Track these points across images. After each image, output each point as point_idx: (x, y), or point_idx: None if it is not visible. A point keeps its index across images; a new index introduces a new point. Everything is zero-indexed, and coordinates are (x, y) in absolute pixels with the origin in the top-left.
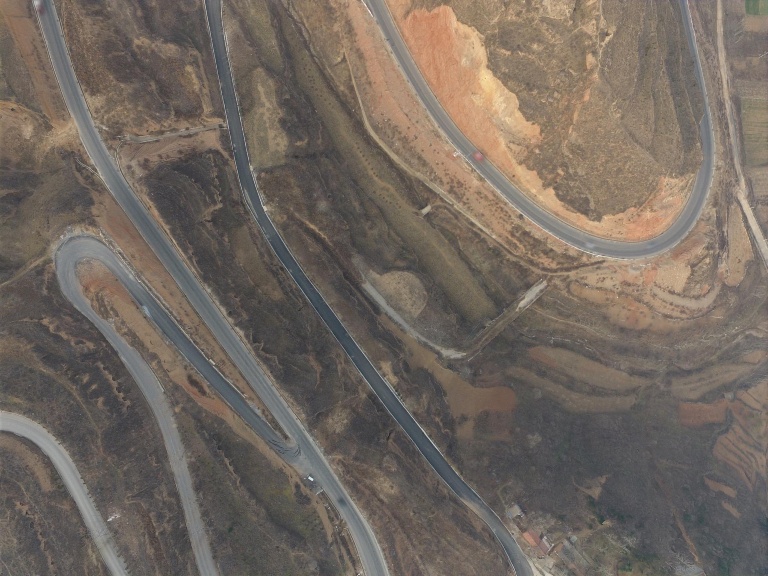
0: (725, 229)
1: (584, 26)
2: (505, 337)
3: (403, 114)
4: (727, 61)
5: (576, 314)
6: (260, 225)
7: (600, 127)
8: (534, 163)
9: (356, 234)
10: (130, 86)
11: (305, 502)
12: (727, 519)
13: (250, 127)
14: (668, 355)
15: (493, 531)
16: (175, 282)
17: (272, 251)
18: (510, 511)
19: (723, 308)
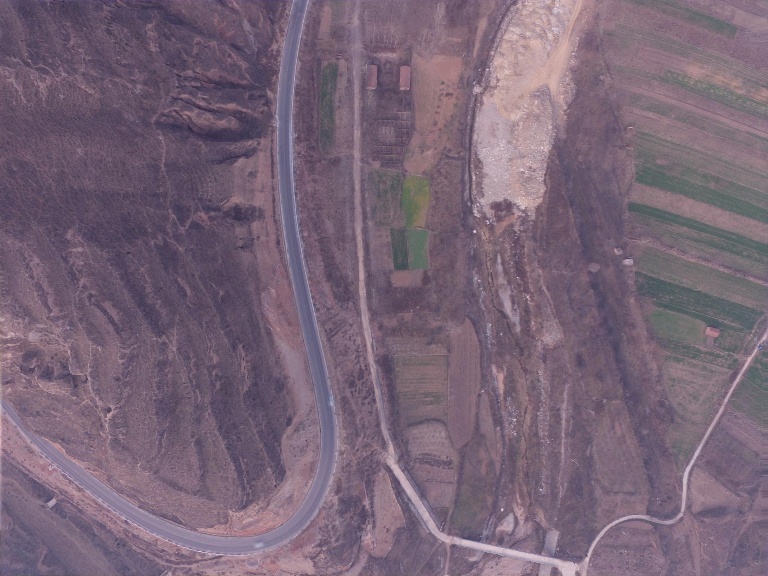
0: (366, 503)
1: (88, 400)
2: None
3: None
4: (373, 322)
5: None
6: None
7: (137, 480)
8: (112, 487)
9: None
10: None
11: None
12: None
13: None
14: None
15: None
16: None
17: None
18: None
19: None
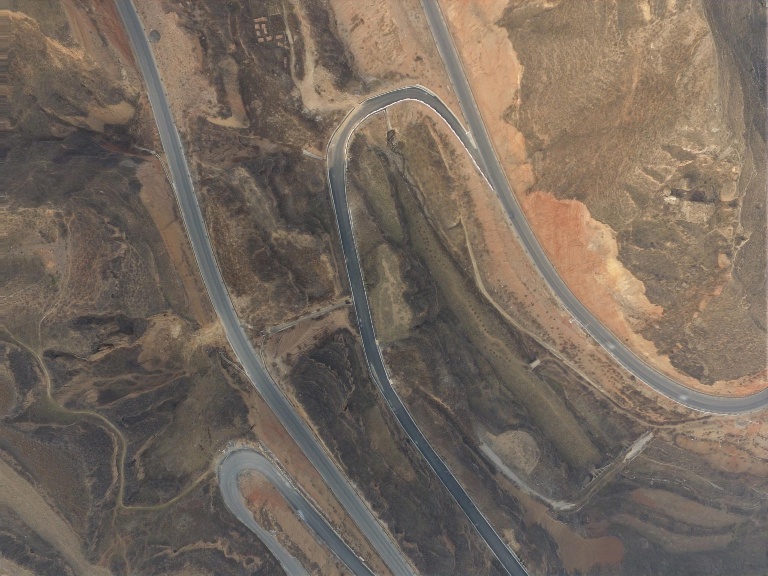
0: None
1: (720, 229)
2: None
3: (521, 283)
4: None
5: (678, 459)
6: (386, 398)
7: (727, 316)
8: (652, 335)
9: (472, 395)
10: (273, 284)
11: None
12: None
13: (375, 302)
14: None
15: None
16: (320, 475)
17: (398, 423)
18: None
19: None
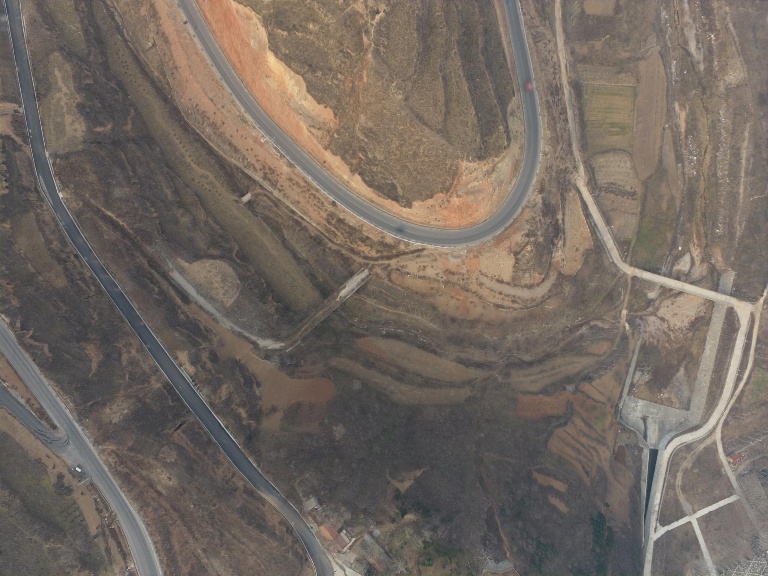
0: (559, 217)
1: (355, 4)
2: (333, 327)
3: (208, 99)
4: (566, 45)
5: (405, 304)
6: (55, 212)
7: (385, 109)
8: (336, 148)
9: (166, 222)
10: None
11: (65, 493)
12: (549, 514)
13: (46, 112)
14: (507, 346)
15: (291, 525)
16: None
17: (67, 238)
18: (306, 504)
19: (558, 298)
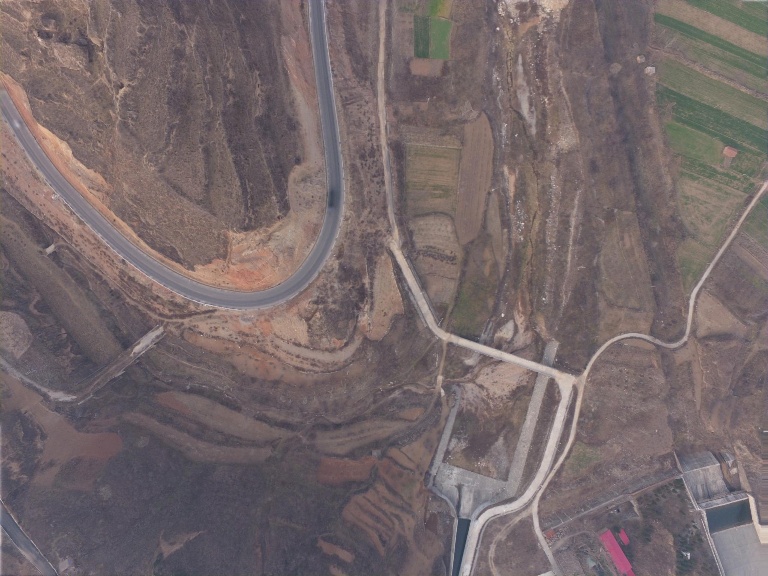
0: (366, 281)
1: (102, 78)
2: (135, 380)
3: (1, 154)
4: (388, 106)
5: (205, 361)
6: None
7: (141, 179)
8: (114, 210)
9: None
10: None
11: None
12: None
13: None
14: (315, 407)
15: None
16: None
17: None
18: (60, 565)
19: (362, 363)
